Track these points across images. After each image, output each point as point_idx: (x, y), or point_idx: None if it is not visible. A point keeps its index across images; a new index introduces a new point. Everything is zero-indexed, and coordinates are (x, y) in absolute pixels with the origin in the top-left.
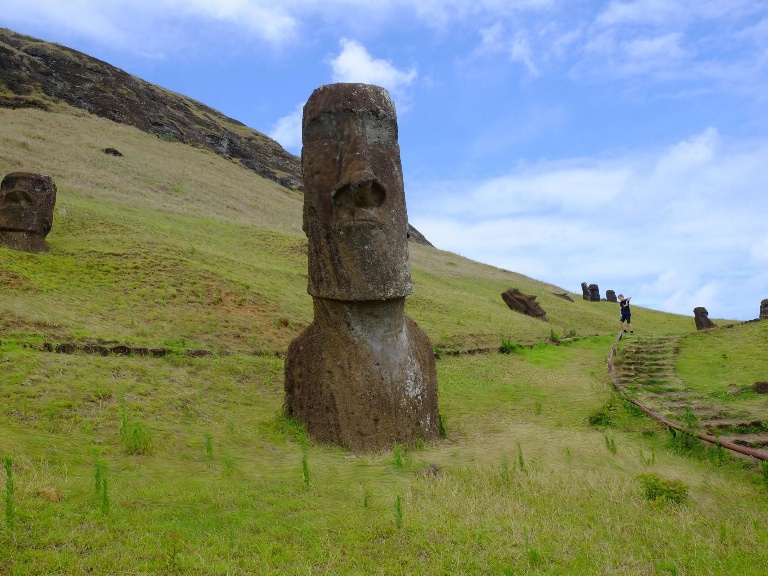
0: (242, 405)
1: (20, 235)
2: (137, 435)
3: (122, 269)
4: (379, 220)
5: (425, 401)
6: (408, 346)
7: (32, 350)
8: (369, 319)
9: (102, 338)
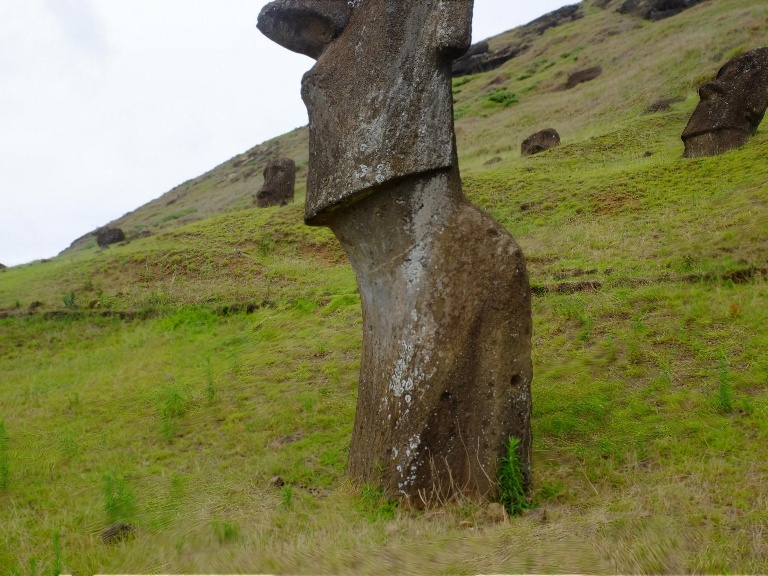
0: None
1: (705, 137)
2: (172, 401)
3: None
4: (314, 69)
5: (417, 407)
6: (421, 289)
7: None
8: (348, 248)
9: (582, 268)
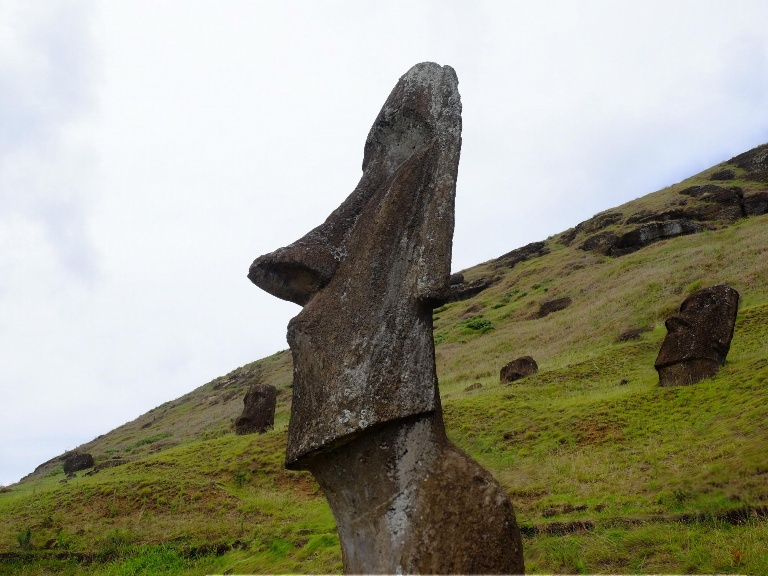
0: None
1: (678, 367)
2: None
3: (767, 379)
4: (301, 316)
5: None
6: (407, 542)
7: None
8: (329, 495)
9: (572, 504)
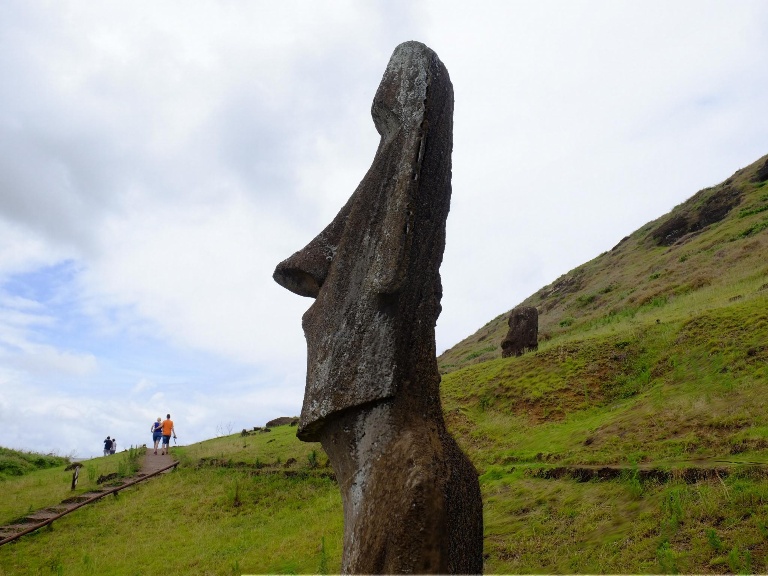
0: (549, 574)
1: None
2: None
3: None
4: None
5: None
6: (360, 513)
7: (526, 476)
8: None
9: (766, 439)
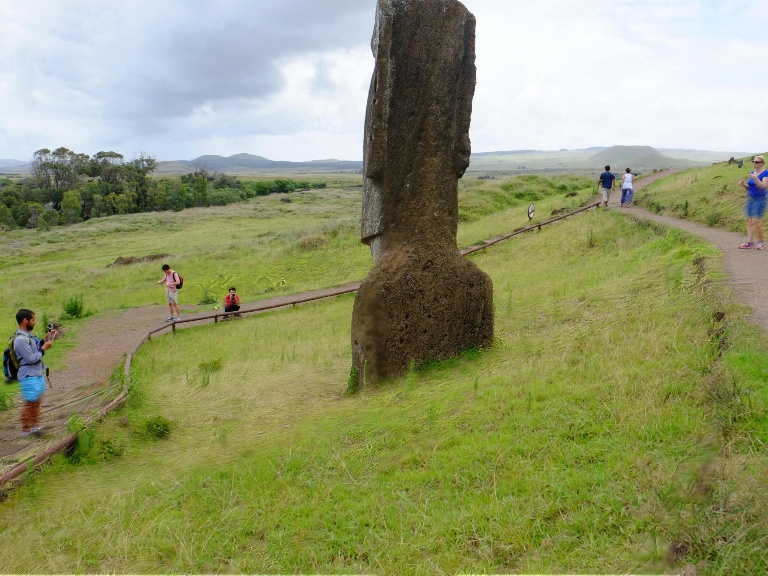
0: None
1: None
2: None
3: None
4: None
5: None
6: None
7: None
8: None
9: None
